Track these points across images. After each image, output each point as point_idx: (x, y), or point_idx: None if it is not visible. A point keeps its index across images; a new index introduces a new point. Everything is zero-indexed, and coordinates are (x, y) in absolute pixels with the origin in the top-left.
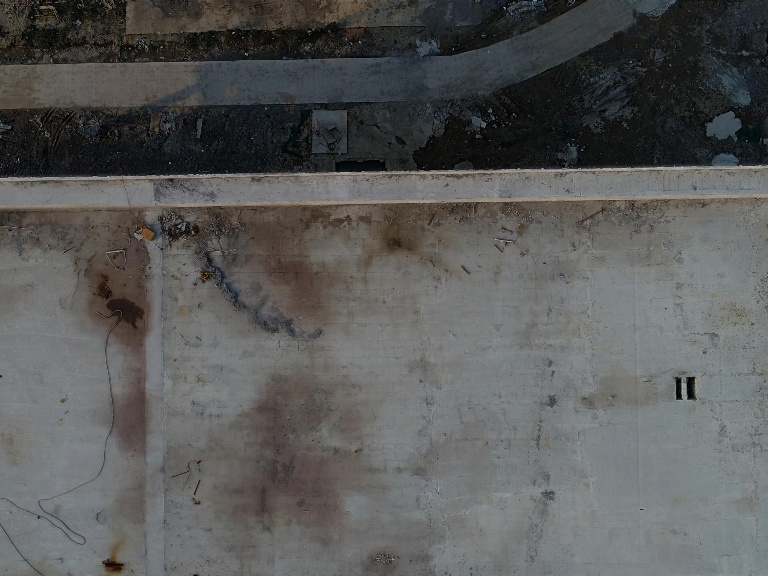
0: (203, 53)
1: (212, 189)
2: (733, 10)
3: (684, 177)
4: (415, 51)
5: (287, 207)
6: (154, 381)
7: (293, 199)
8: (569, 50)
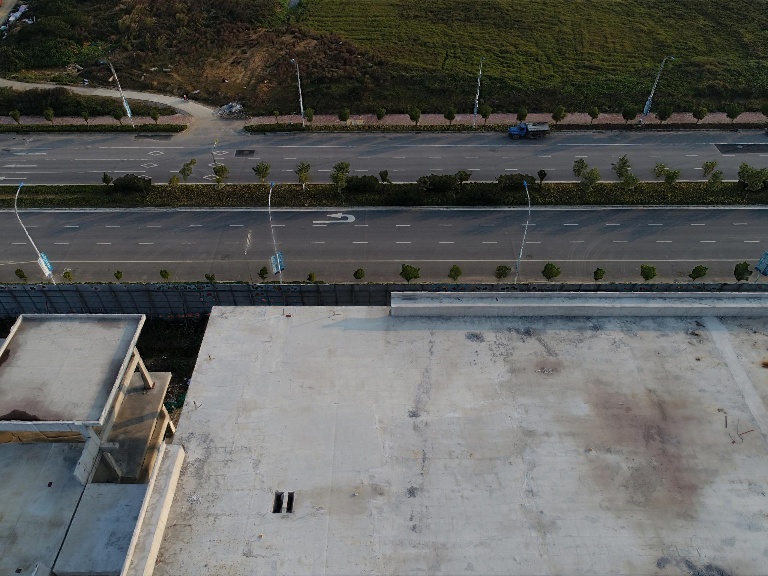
0: None
1: None
2: None
3: None
4: None
5: None
6: None
7: None
8: None
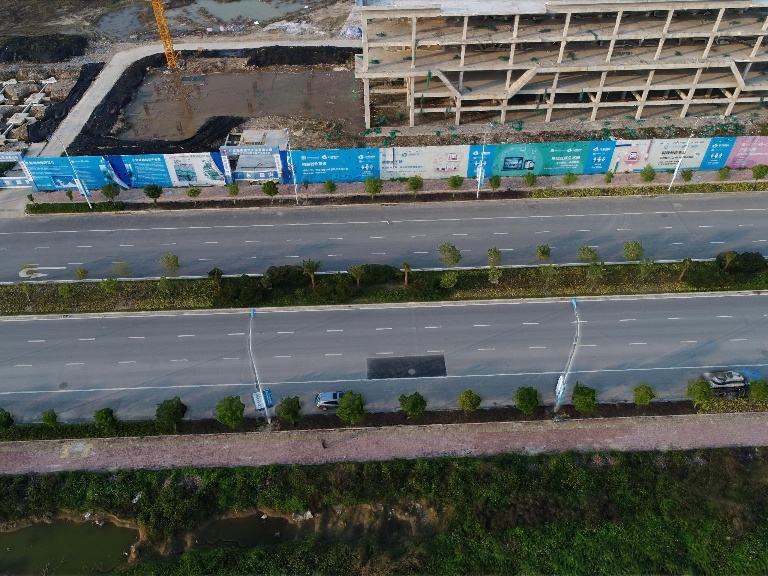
0: None
1: None
2: None
3: None
4: None
5: None
6: None
7: None
8: None
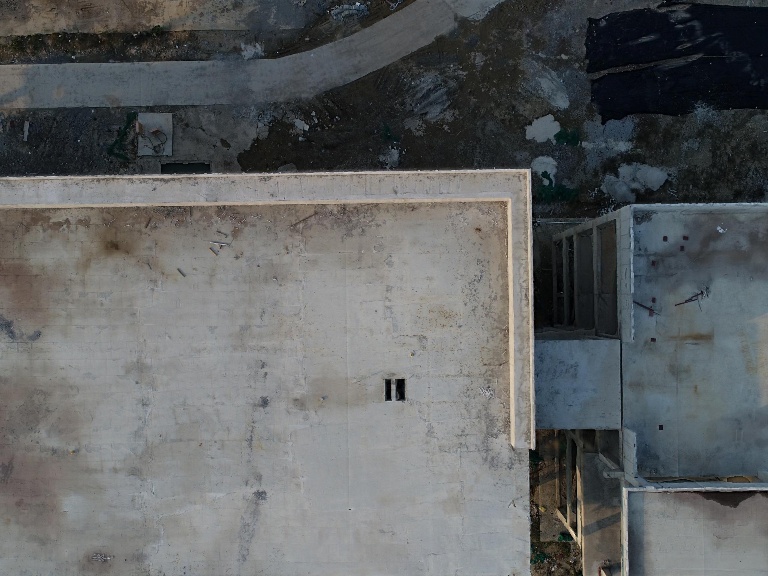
0: (31, 56)
1: None
2: (552, 14)
3: (385, 181)
4: (240, 54)
5: (6, 210)
6: None
7: (5, 203)
8: (391, 53)
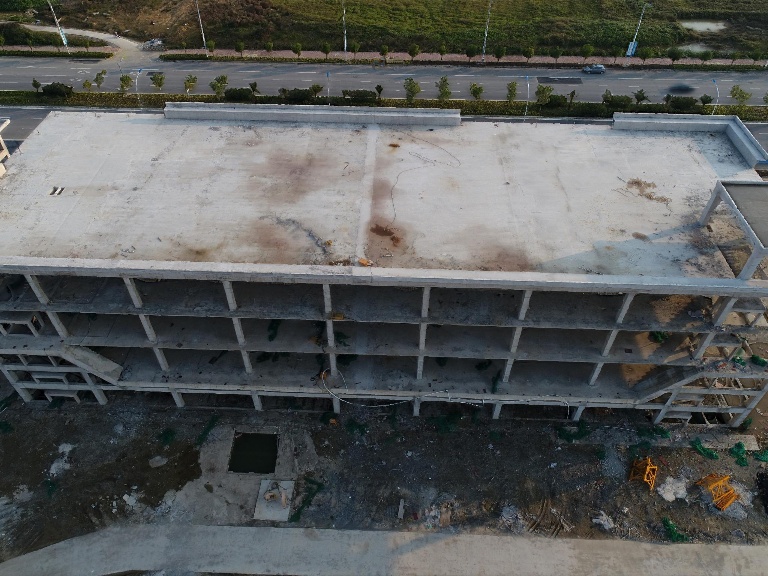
0: None
1: (312, 271)
2: None
3: None
4: None
5: None
6: (366, 203)
7: (258, 265)
8: (10, 568)
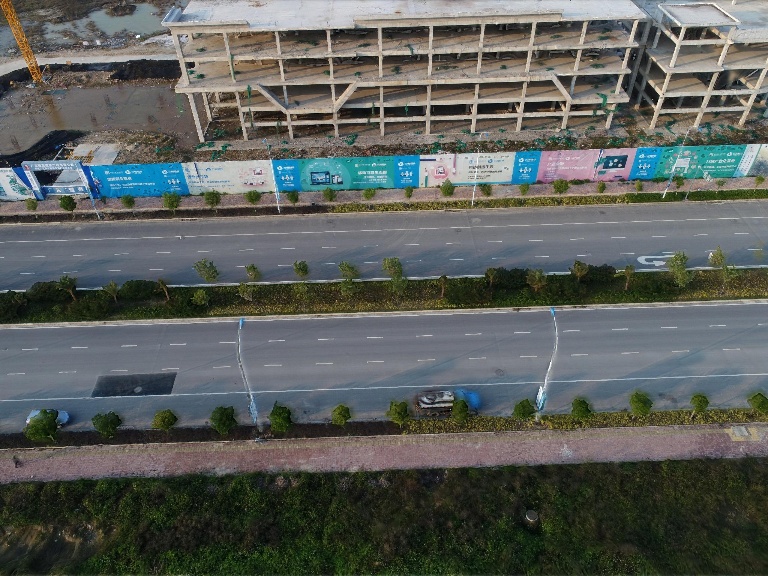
0: None
1: None
2: None
3: None
4: None
5: None
6: None
7: None
8: None
